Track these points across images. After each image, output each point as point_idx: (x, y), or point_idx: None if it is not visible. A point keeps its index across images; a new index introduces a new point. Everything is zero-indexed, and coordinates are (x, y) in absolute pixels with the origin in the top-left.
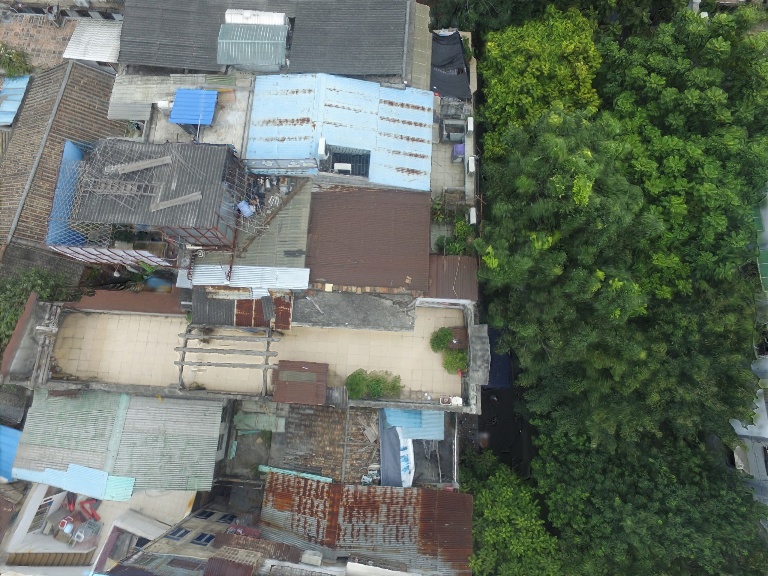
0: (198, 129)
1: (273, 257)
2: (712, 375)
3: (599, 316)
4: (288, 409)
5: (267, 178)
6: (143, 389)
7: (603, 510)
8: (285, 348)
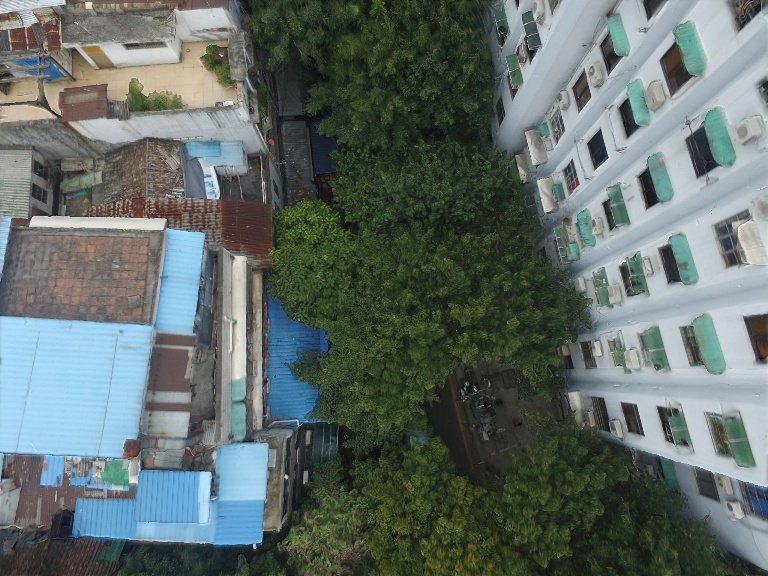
0: None
1: None
2: (440, 47)
3: (330, 1)
4: (104, 164)
5: None
6: None
7: (378, 192)
8: None
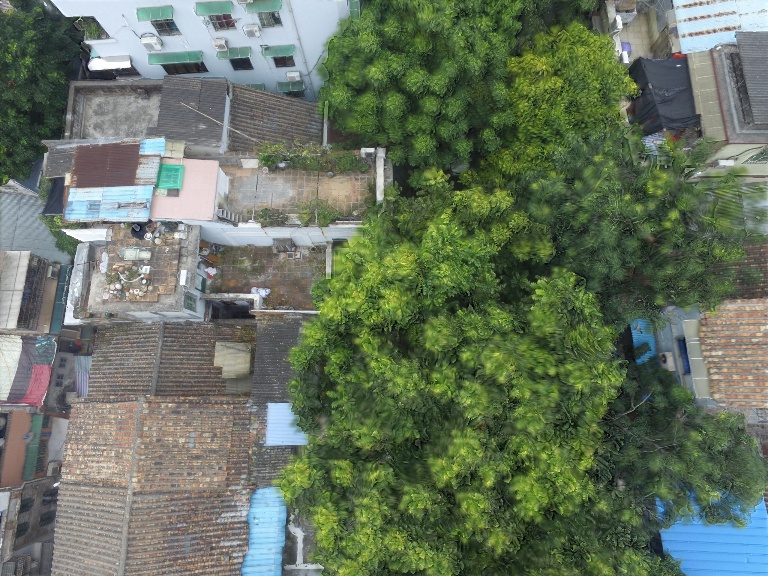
0: None
1: None
2: None
3: None
4: None
5: None
6: None
7: None
8: None
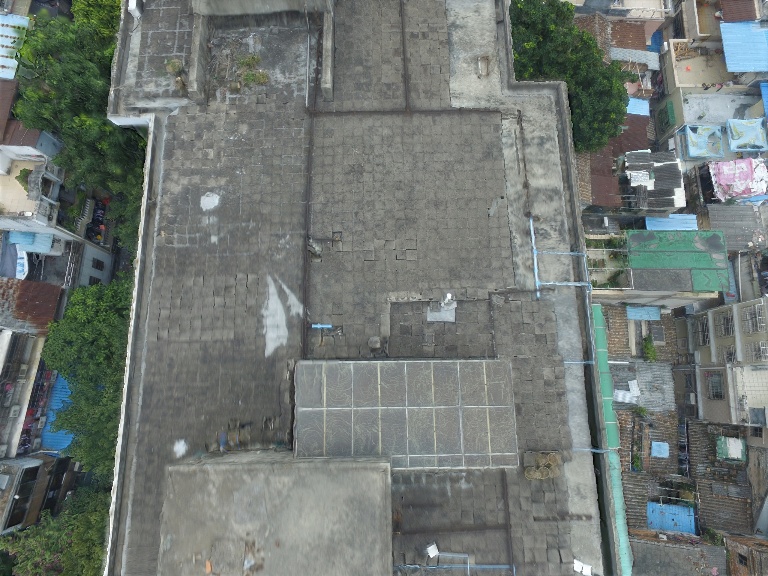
0: None
1: None
2: None
3: None
4: None
5: None
6: None
7: None
8: None
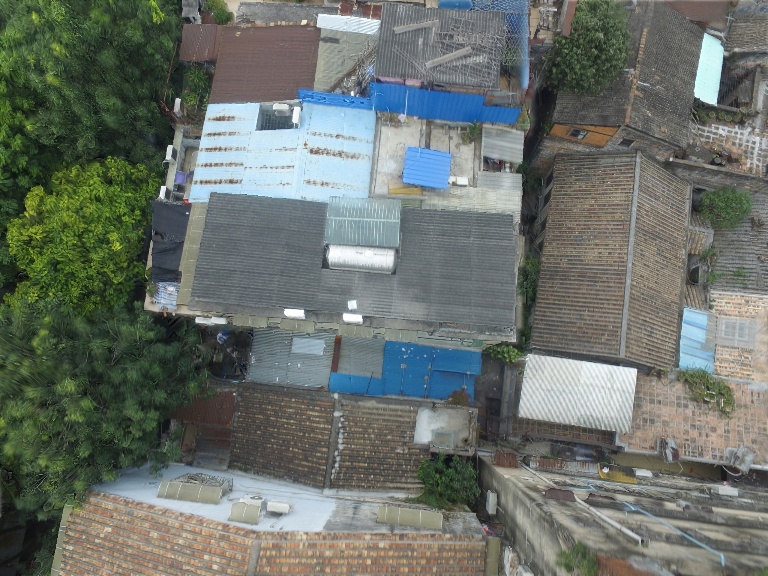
0: None
1: (350, 40)
2: None
3: None
4: None
5: None
6: None
7: None
8: None
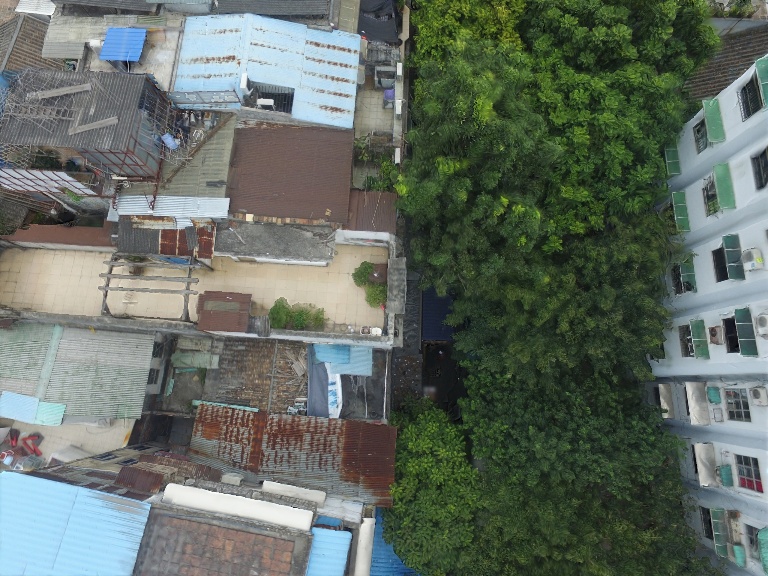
0: (128, 67)
1: (196, 188)
2: (621, 307)
3: (510, 247)
4: (222, 347)
5: (192, 112)
6: (72, 317)
7: (520, 440)
8: (215, 283)
